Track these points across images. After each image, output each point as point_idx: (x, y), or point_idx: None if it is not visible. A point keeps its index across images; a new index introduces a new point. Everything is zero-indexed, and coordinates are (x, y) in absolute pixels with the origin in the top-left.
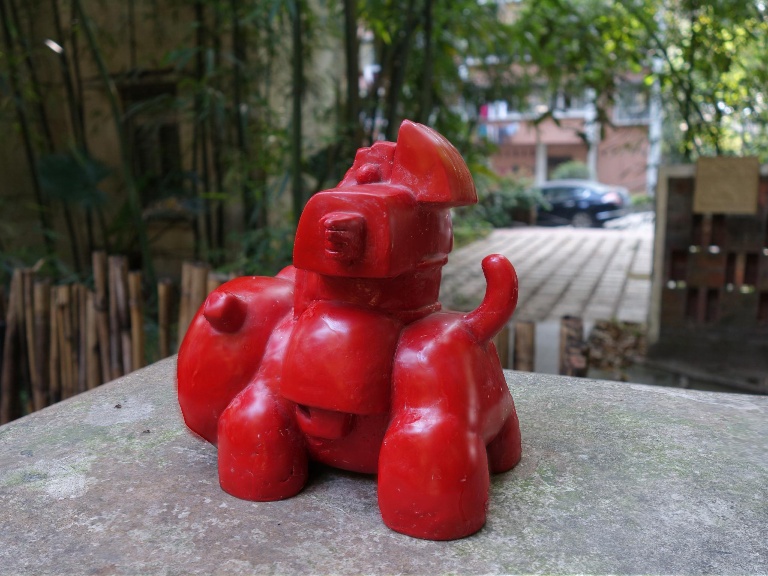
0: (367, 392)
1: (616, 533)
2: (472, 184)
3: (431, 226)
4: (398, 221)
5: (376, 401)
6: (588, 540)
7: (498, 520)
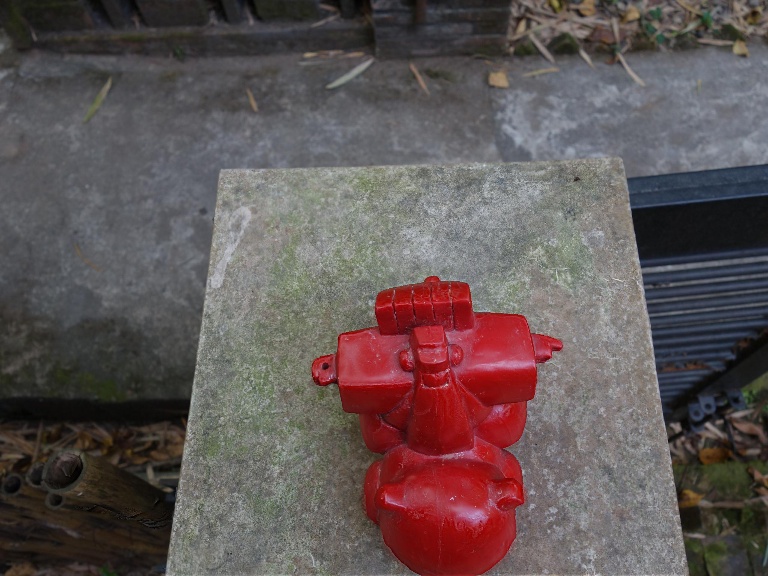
0: None
1: (459, 277)
2: None
3: None
4: None
5: None
6: (472, 288)
7: None
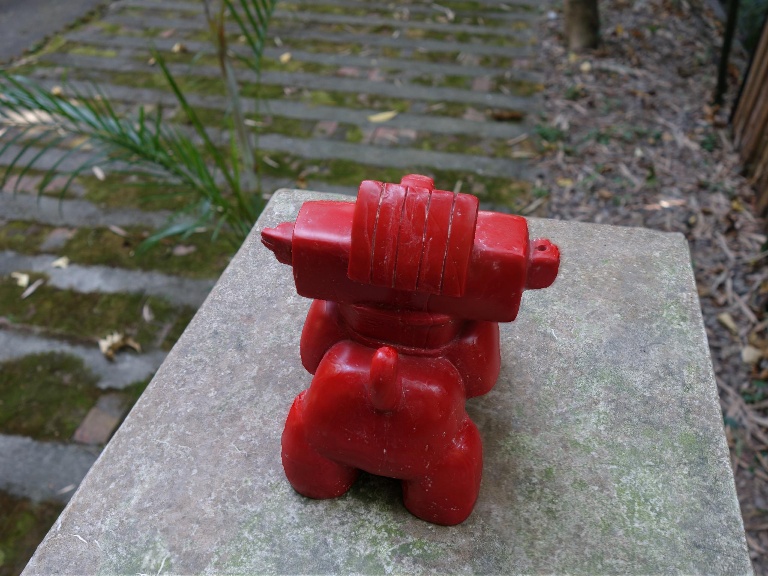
0: (303, 354)
1: None
2: (432, 276)
3: None
4: (305, 262)
5: (309, 365)
6: None
7: (321, 508)
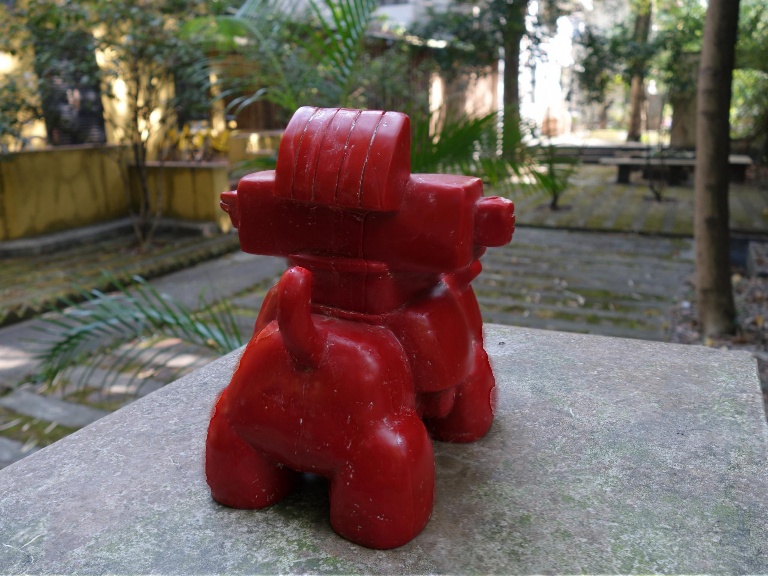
0: None
1: None
2: (351, 184)
3: (322, 222)
4: (247, 205)
5: None
6: (175, 572)
7: (233, 516)
